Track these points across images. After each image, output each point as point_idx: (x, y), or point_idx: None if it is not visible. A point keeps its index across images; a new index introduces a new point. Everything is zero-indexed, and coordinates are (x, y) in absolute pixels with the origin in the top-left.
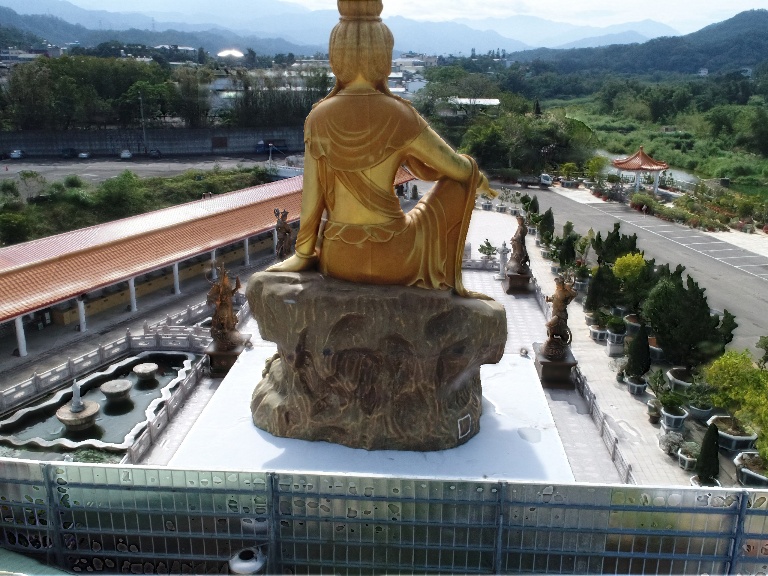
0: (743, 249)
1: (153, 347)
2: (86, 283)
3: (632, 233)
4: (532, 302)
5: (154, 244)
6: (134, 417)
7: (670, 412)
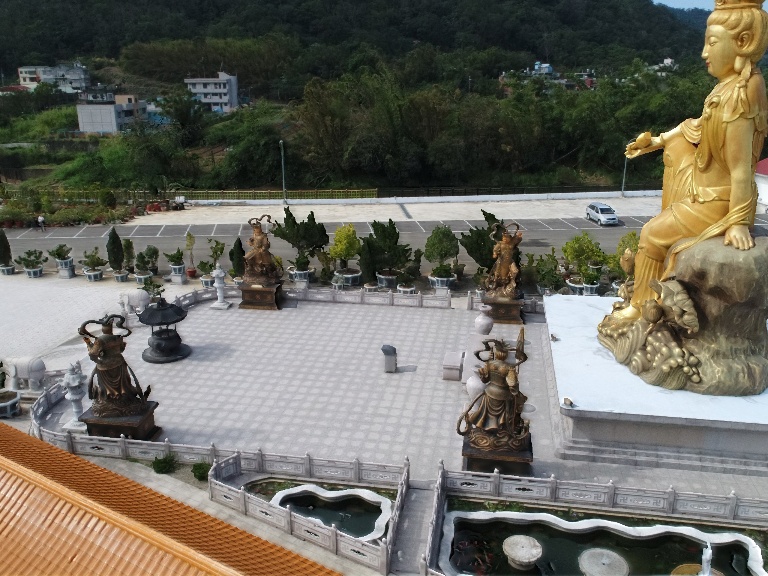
0: (192, 225)
1: (432, 553)
2: (313, 573)
3: (95, 243)
4: (311, 303)
5: (80, 487)
6: (633, 569)
7: (595, 284)
